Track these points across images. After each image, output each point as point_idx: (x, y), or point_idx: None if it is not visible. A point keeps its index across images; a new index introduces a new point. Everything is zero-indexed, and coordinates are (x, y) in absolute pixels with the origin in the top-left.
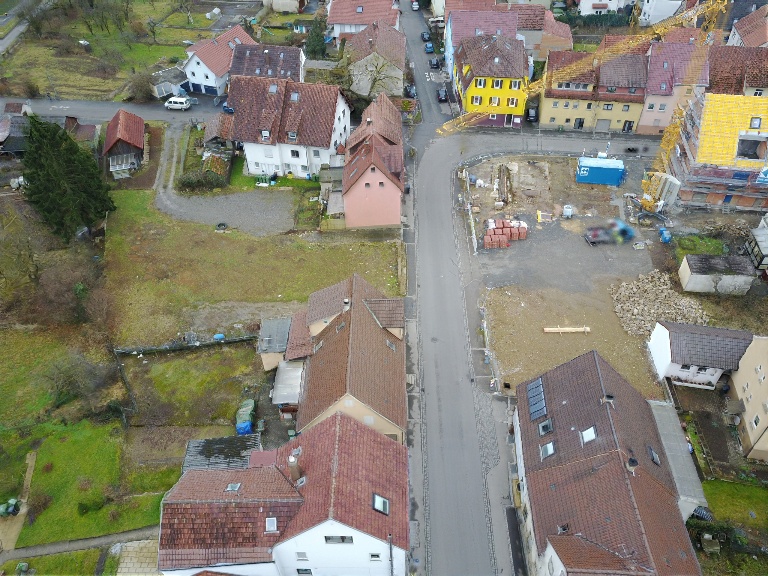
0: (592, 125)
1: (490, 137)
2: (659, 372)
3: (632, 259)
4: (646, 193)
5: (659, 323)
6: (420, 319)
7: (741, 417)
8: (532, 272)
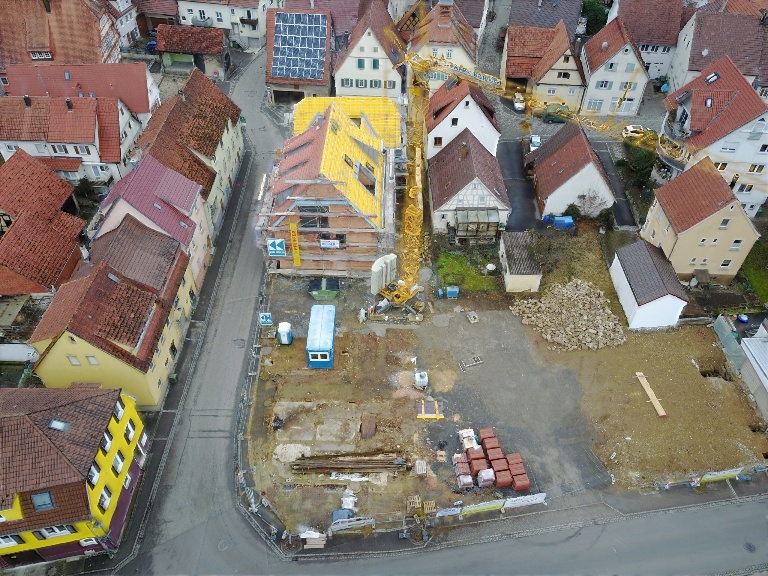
0: (181, 335)
1: (175, 494)
2: (668, 324)
3: (496, 326)
4: (413, 286)
5: (646, 303)
6: (722, 573)
7: (709, 275)
8: (559, 427)
